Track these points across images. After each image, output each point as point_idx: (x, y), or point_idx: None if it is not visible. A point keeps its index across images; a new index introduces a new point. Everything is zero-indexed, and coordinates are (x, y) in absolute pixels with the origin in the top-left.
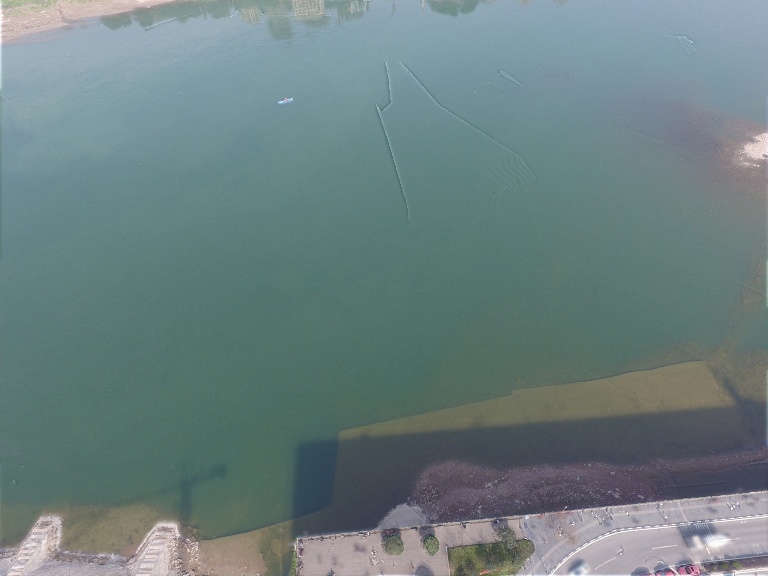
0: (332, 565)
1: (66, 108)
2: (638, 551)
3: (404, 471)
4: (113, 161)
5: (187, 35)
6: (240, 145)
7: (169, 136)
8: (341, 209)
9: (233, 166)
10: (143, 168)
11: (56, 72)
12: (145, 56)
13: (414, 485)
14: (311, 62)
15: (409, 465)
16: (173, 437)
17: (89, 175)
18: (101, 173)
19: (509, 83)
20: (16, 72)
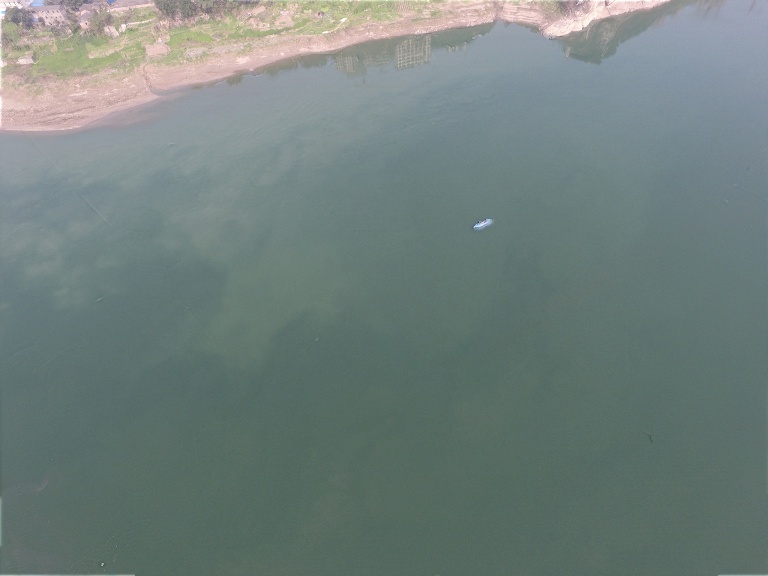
0: None
1: (185, 232)
2: None
3: None
4: (275, 333)
5: (311, 111)
6: (450, 305)
7: (341, 285)
8: (638, 429)
9: (456, 348)
10: (322, 348)
11: (159, 171)
12: (268, 145)
13: None
14: (481, 151)
15: None
16: None
17: (248, 361)
18: (264, 357)
19: (766, 185)
20: (107, 170)
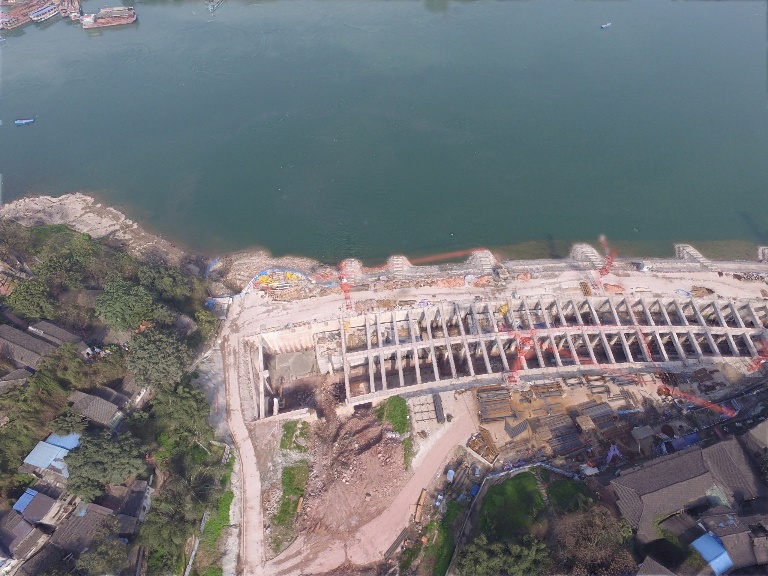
0: None
1: (421, 34)
2: None
3: None
4: (501, 66)
5: None
6: (597, 54)
7: (529, 50)
8: None
9: (606, 66)
10: (531, 69)
11: (386, 11)
12: None
13: None
14: (590, 3)
15: None
16: None
17: (492, 74)
18: (500, 73)
19: None
20: (351, 12)
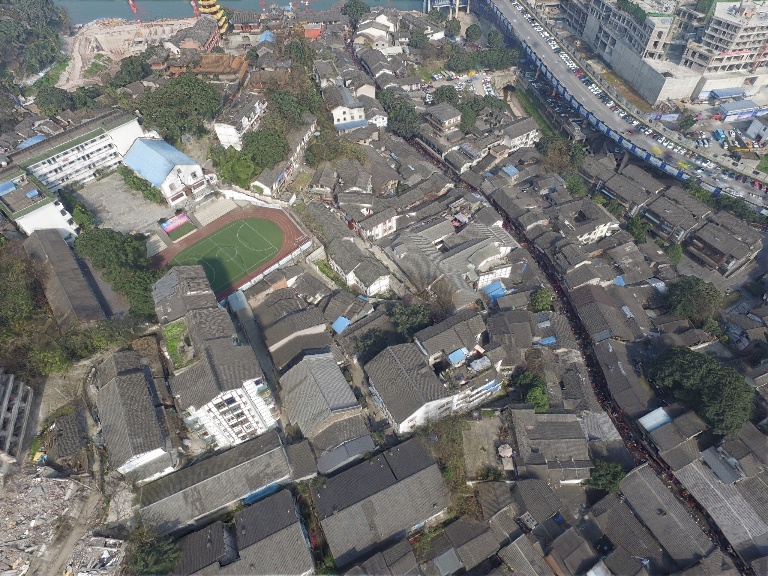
0: None
1: None
2: None
3: None
4: None
5: None
6: None
7: None
8: None
9: None
10: None
11: None
12: None
13: None
14: None
15: None
16: None
17: None
18: None
19: None
20: None
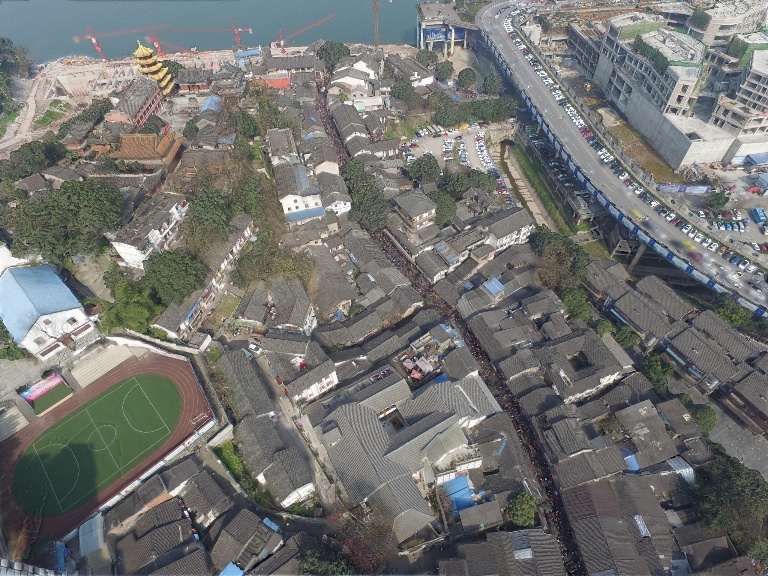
0: None
1: None
2: (525, 1)
3: None
4: None
5: None
6: None
7: None
8: None
9: None
10: None
11: None
12: None
13: None
14: None
15: None
16: None
17: None
18: None
19: None
20: None
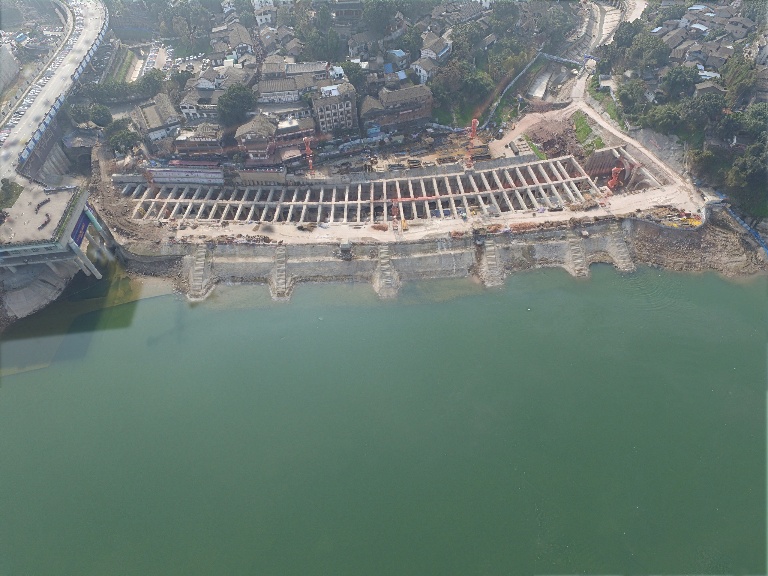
0: (38, 232)
1: None
2: None
3: (8, 339)
4: None
5: None
6: None
7: None
8: None
9: None
10: None
11: None
12: None
13: (6, 330)
14: None
15: (2, 343)
16: (198, 355)
17: None
18: None
19: None
20: None
